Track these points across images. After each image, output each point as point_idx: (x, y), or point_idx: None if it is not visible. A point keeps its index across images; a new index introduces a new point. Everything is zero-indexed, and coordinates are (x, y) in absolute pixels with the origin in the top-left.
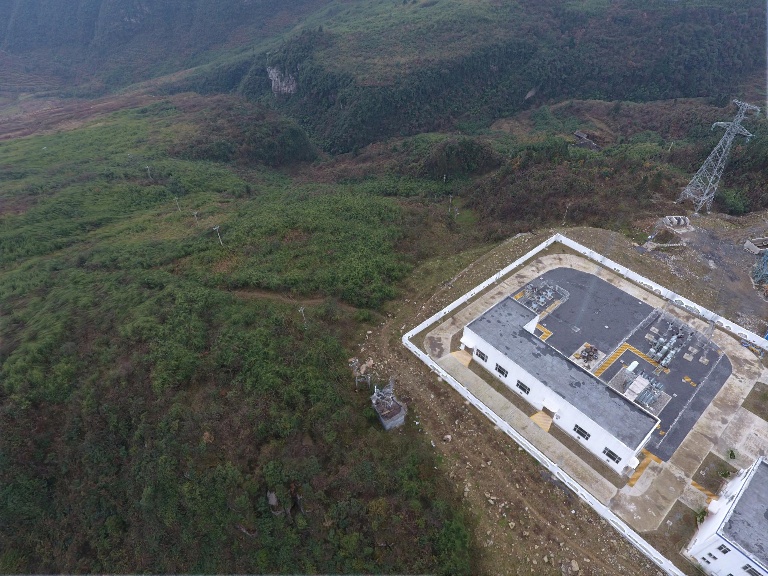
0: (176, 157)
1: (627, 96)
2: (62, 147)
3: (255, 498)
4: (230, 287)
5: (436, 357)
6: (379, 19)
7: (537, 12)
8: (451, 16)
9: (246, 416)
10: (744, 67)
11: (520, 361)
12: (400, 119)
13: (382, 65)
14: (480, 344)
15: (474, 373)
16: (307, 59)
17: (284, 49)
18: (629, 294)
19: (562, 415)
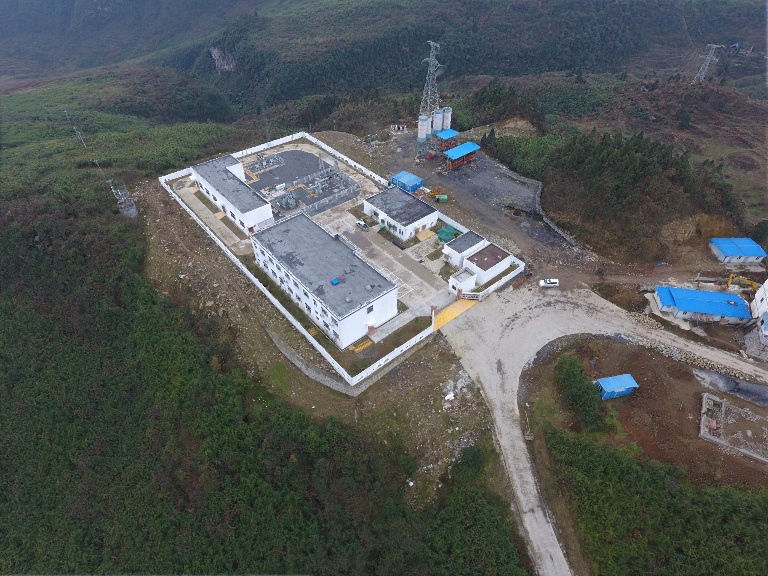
0: (100, 110)
1: (522, 74)
2: (8, 103)
3: (27, 238)
4: (76, 166)
5: (177, 189)
6: (311, 6)
7: (448, 0)
8: (369, 3)
9: (35, 204)
10: (625, 50)
11: (212, 182)
12: (317, 91)
13: (303, 44)
14: (197, 177)
15: (195, 196)
16: (242, 40)
17: (224, 31)
18: (327, 163)
19: (226, 208)
